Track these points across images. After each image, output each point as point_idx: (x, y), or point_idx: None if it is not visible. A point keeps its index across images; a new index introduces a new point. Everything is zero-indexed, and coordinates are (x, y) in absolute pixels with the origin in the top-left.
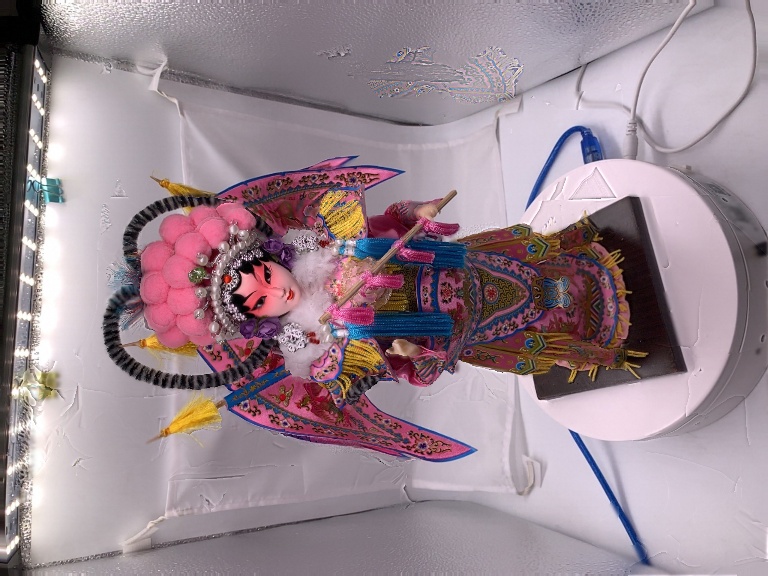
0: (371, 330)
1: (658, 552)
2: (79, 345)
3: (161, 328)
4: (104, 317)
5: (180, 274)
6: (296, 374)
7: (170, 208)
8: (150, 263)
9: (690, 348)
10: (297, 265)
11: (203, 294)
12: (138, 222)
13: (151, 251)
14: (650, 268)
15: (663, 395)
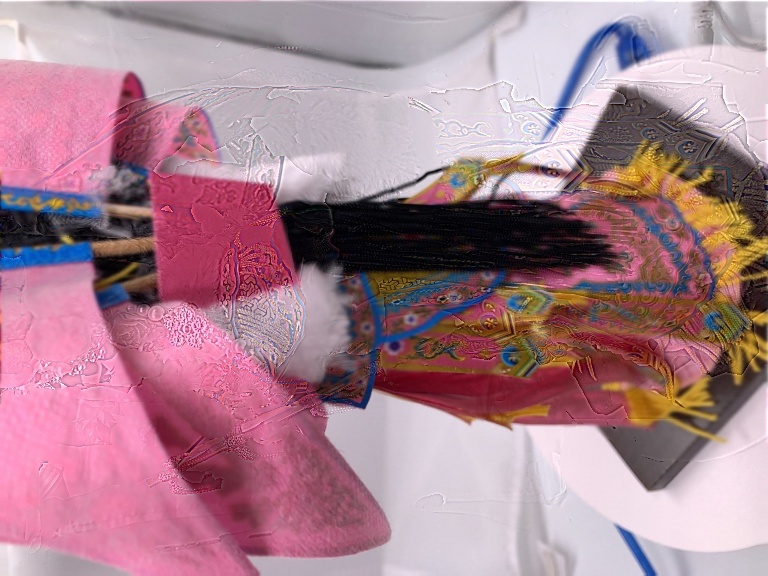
0: None
1: (437, 491)
2: None
3: None
4: None
5: None
6: None
7: None
8: None
9: (627, 416)
10: (163, 352)
11: None
12: None
13: None
14: (683, 358)
15: (577, 392)
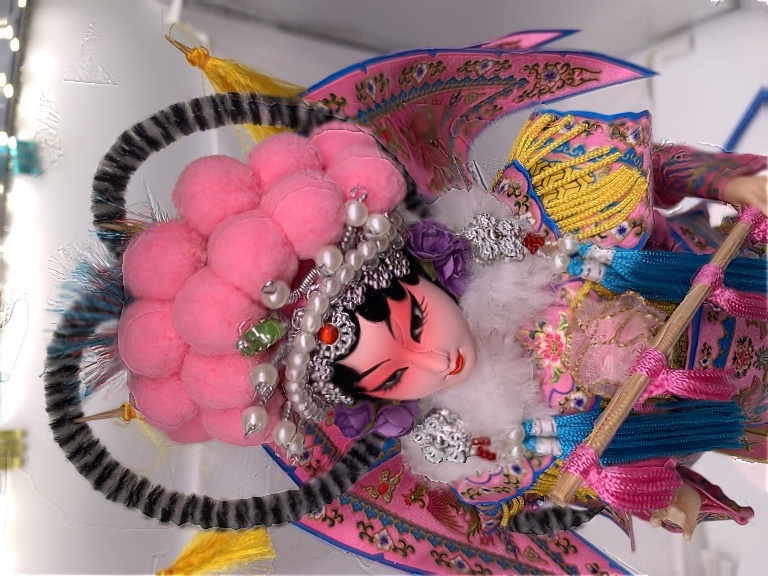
0: (609, 449)
1: None
2: (0, 389)
3: (163, 426)
4: (47, 352)
5: (216, 331)
6: (421, 472)
7: (205, 125)
8: (143, 282)
9: None
10: (474, 290)
11: (269, 383)
12: (128, 151)
13: (147, 253)
14: None
15: None
